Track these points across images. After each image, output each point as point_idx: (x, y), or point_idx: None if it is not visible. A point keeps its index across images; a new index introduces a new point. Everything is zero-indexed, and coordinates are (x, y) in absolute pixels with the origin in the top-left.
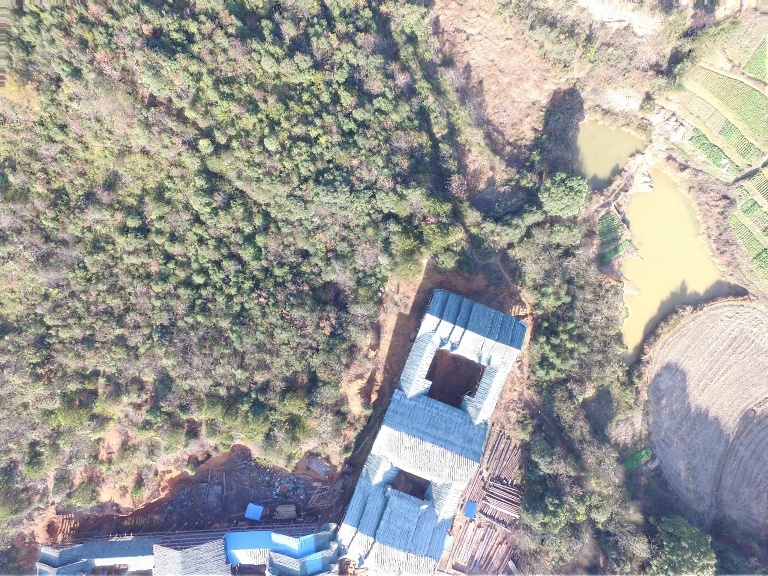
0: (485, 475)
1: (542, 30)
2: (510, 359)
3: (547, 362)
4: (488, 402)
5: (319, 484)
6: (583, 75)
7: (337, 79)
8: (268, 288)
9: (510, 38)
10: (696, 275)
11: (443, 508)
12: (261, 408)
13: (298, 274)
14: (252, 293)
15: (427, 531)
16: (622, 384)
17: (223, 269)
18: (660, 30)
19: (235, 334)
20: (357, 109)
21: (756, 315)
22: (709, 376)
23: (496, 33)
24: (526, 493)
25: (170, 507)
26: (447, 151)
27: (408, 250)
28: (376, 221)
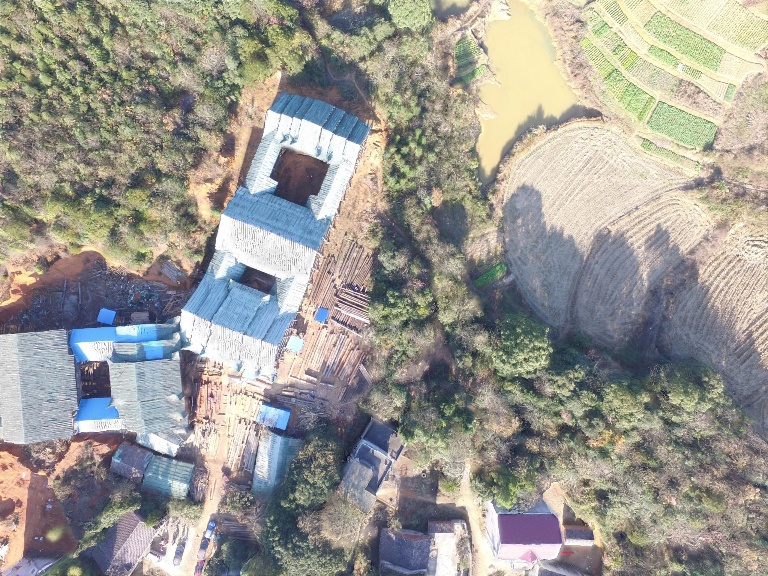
0: (338, 283)
1: None
2: (352, 156)
3: (398, 173)
4: (330, 198)
5: (173, 292)
6: None
7: None
8: (115, 89)
9: None
10: (552, 99)
11: (285, 300)
12: (106, 204)
13: (147, 78)
14: None
15: (267, 320)
16: (474, 197)
17: (69, 69)
18: None
19: (78, 129)
20: None
21: (610, 137)
22: (564, 196)
23: None
24: (373, 294)
25: (25, 316)
26: None
27: (254, 54)
28: (225, 28)
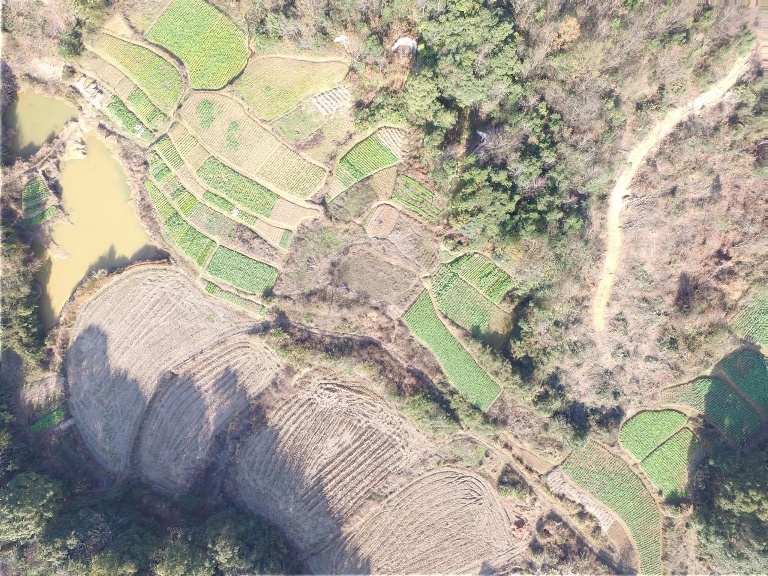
0: None
1: None
2: None
3: None
4: None
5: None
6: (4, 44)
7: None
8: None
9: None
10: (123, 240)
11: None
12: None
13: None
14: None
15: None
16: (23, 345)
17: None
18: None
19: None
20: None
21: (178, 279)
22: (130, 339)
23: None
24: None
25: None
26: None
27: None
28: None
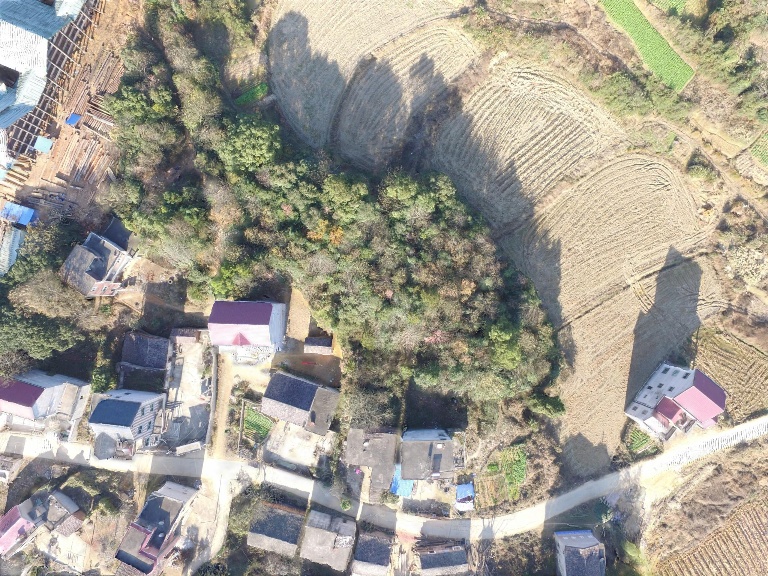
0: (92, 91)
1: None
2: None
3: None
4: None
5: None
6: None
7: None
8: None
9: None
10: None
11: (21, 91)
12: None
13: None
14: None
15: None
16: (233, 15)
17: None
18: None
19: None
20: None
21: None
22: (330, 22)
23: None
24: None
25: None
26: None
27: None
28: None
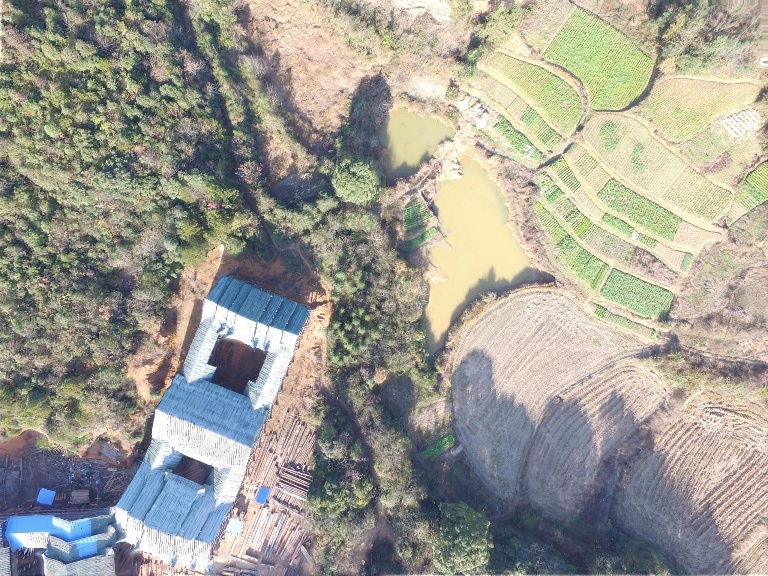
0: (280, 461)
1: (345, 17)
2: (290, 344)
3: (342, 348)
4: (268, 387)
5: (114, 469)
6: (387, 62)
7: (124, 66)
8: (52, 274)
9: (318, 26)
10: (504, 262)
11: (221, 492)
12: (42, 393)
13: (85, 260)
14: (33, 279)
15: (202, 515)
16: (420, 370)
17: (6, 255)
18: (458, 16)
19: (14, 319)
20: (139, 96)
21: (563, 302)
22: (515, 363)
23: (305, 21)
24: None
25: None
26: (240, 138)
27: (193, 236)
28: (164, 207)
